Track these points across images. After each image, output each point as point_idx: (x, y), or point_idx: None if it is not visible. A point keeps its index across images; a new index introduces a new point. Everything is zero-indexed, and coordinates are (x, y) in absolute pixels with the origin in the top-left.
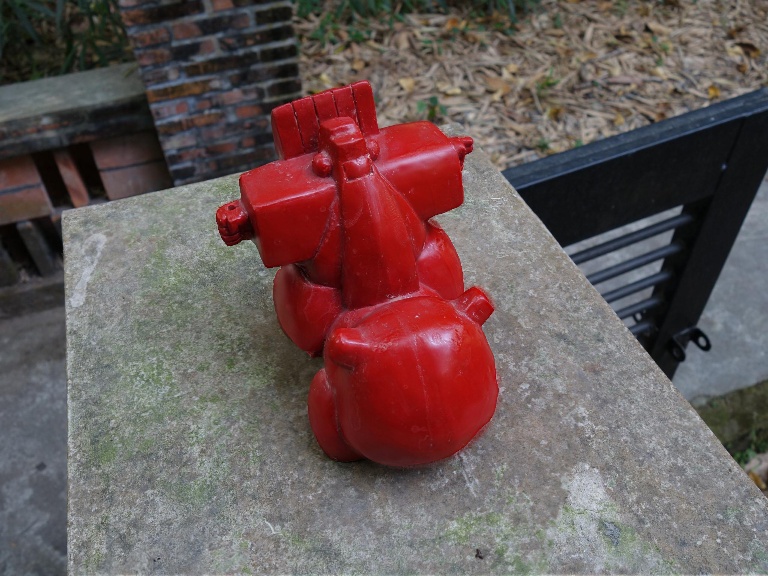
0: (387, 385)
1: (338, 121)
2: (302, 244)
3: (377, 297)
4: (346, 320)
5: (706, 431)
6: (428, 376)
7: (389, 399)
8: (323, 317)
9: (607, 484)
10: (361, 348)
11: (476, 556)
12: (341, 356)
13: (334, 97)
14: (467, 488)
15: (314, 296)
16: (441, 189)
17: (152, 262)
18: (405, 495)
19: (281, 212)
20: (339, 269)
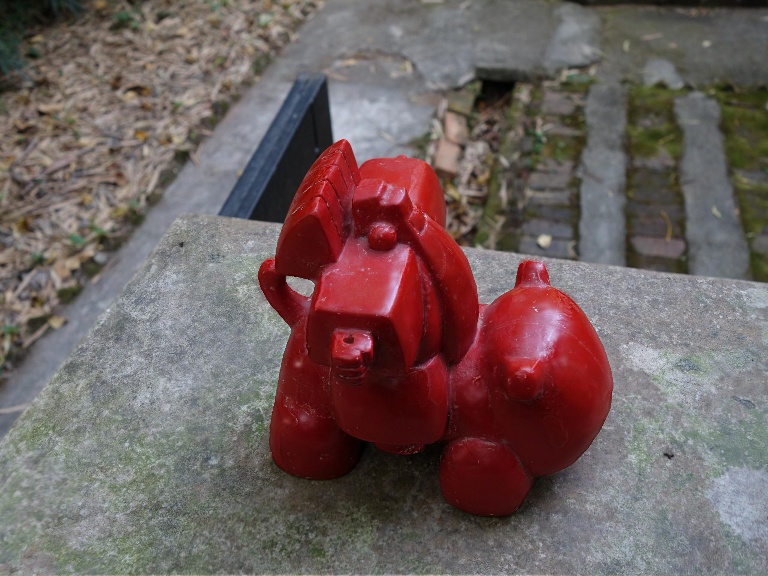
0: (575, 378)
1: (369, 186)
2: (418, 326)
3: (474, 330)
4: (464, 374)
5: (631, 270)
6: (588, 344)
7: (583, 388)
8: (444, 390)
9: (646, 344)
10: (540, 366)
11: (670, 458)
12: (536, 386)
13: (339, 169)
14: (602, 430)
15: (431, 376)
16: (441, 204)
17: (71, 570)
18: (583, 477)
19: (403, 303)
20: (441, 329)
